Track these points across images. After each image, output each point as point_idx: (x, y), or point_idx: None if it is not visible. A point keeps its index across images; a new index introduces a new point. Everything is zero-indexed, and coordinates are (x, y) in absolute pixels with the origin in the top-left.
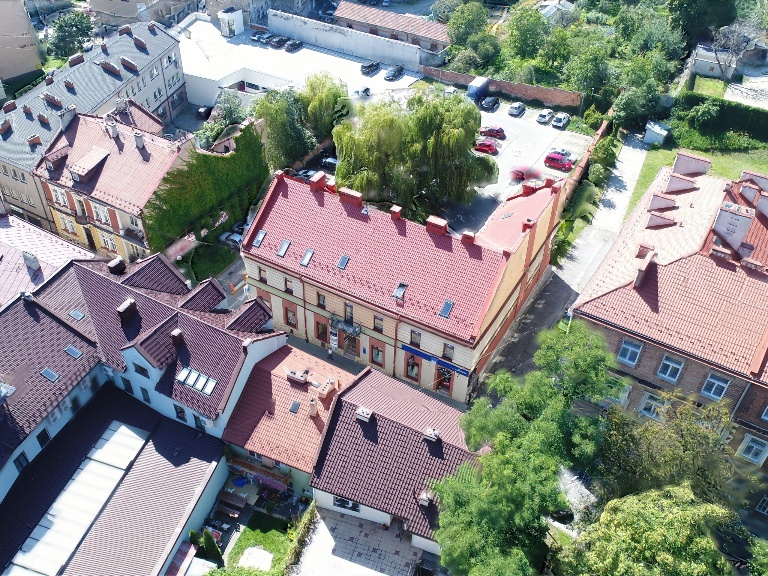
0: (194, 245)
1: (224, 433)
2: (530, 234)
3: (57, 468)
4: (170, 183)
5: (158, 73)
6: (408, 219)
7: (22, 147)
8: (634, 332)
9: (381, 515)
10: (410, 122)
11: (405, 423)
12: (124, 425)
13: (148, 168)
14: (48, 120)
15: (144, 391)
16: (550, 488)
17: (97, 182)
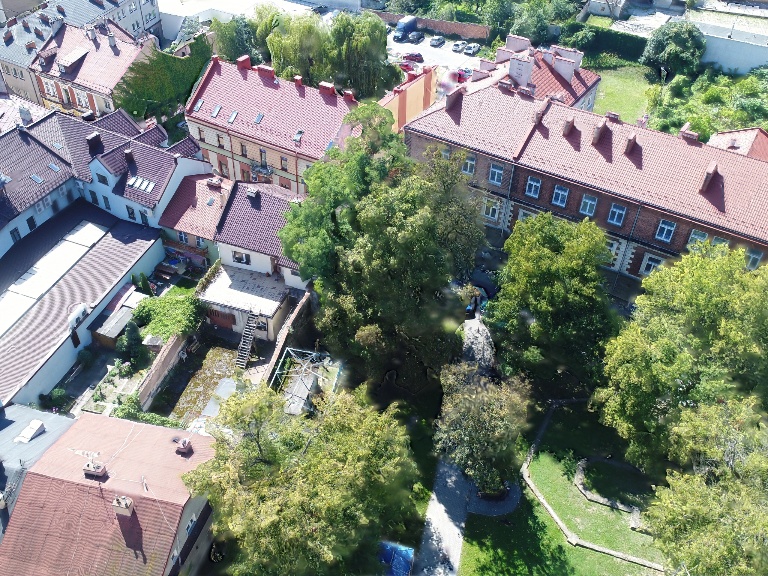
0: (146, 103)
1: (160, 220)
2: (399, 98)
3: (41, 243)
4: (135, 72)
5: (136, 8)
6: (307, 86)
7: (21, 51)
8: (442, 138)
9: (265, 265)
10: (329, 33)
11: (280, 197)
12: (91, 223)
13: (118, 61)
14: (42, 33)
15: (106, 200)
16: (341, 187)
17: (79, 72)
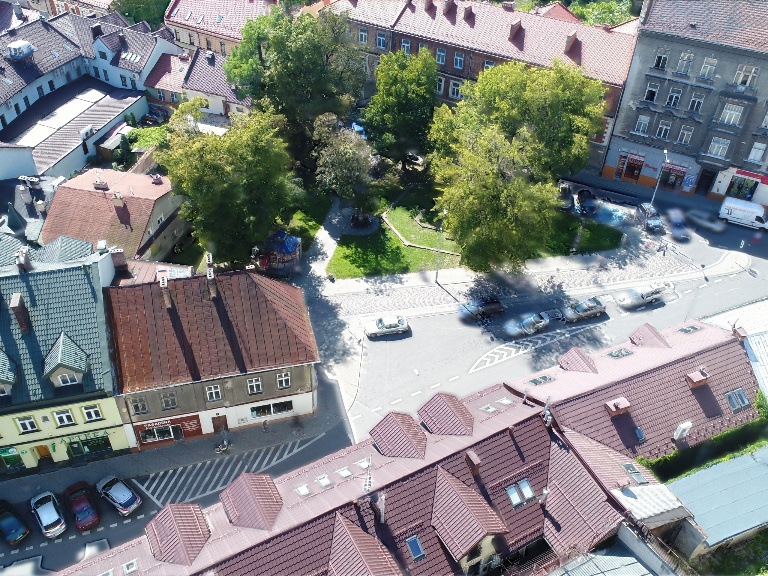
0: (135, 7)
1: (145, 82)
2: (324, 4)
3: (59, 99)
4: None
5: None
6: None
7: None
8: None
9: (219, 107)
10: None
11: None
12: (94, 89)
13: None
14: None
15: (105, 73)
16: (262, 29)
17: None
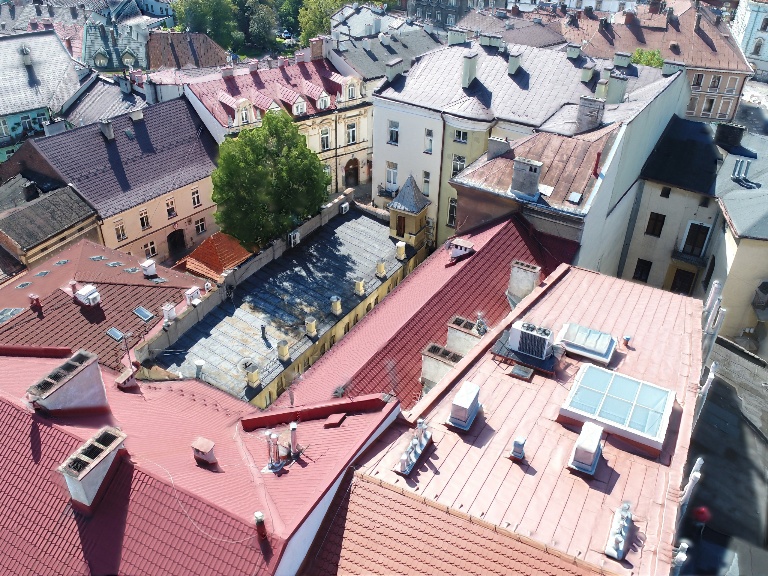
0: None
1: None
2: None
3: None
4: None
5: None
6: None
7: None
8: None
9: None
10: None
11: None
12: (146, 15)
13: None
14: None
15: (152, 7)
16: None
17: None
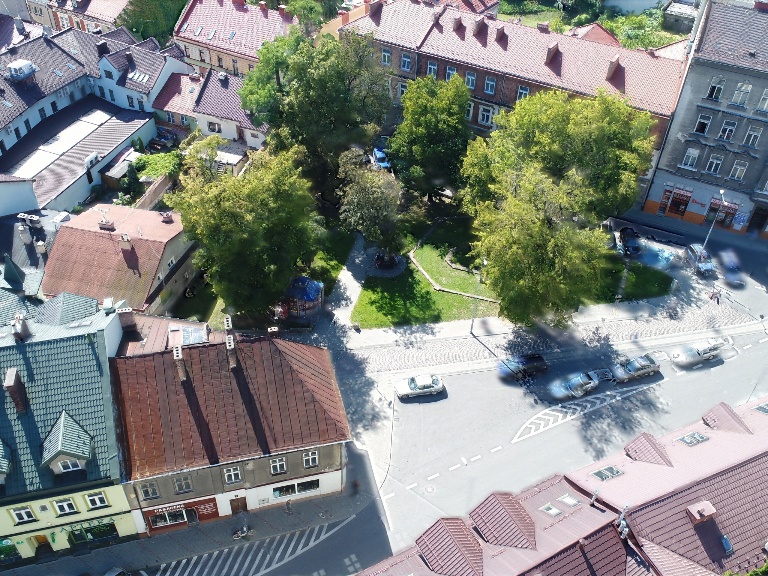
0: (143, 22)
1: (153, 104)
2: (343, 19)
3: (62, 121)
4: (134, 6)
5: None
6: (270, 9)
7: None
8: None
9: (232, 132)
10: None
11: None
12: (100, 110)
13: None
14: None
15: (111, 93)
16: (281, 53)
17: (88, 7)
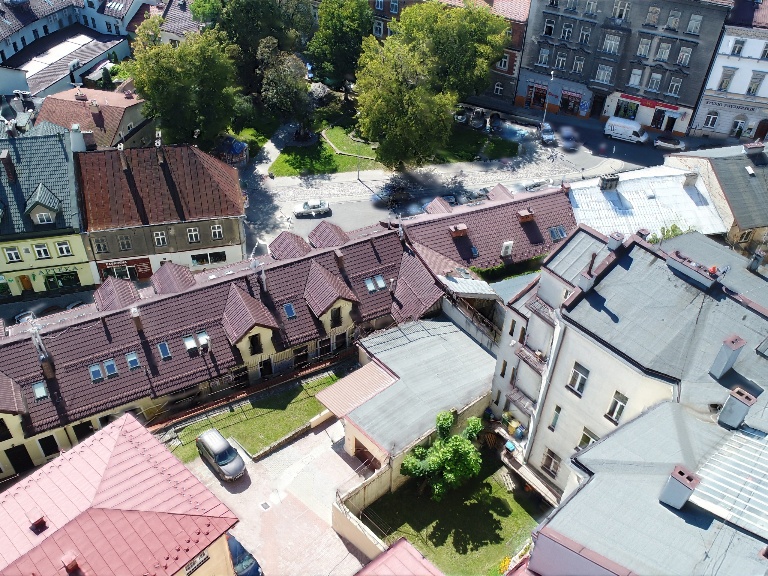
0: None
1: (127, 27)
2: None
3: (52, 41)
4: None
5: None
6: None
7: None
8: None
9: None
10: None
11: None
12: (83, 35)
13: None
14: None
15: (93, 21)
16: None
17: None
